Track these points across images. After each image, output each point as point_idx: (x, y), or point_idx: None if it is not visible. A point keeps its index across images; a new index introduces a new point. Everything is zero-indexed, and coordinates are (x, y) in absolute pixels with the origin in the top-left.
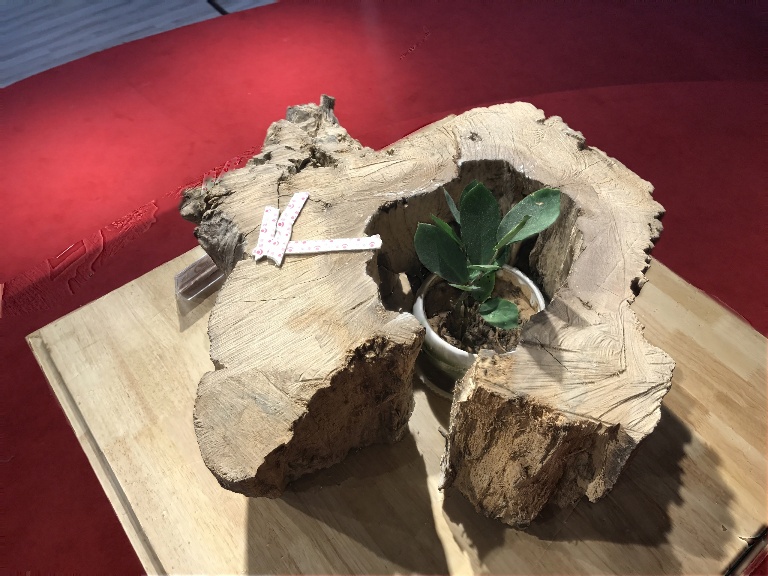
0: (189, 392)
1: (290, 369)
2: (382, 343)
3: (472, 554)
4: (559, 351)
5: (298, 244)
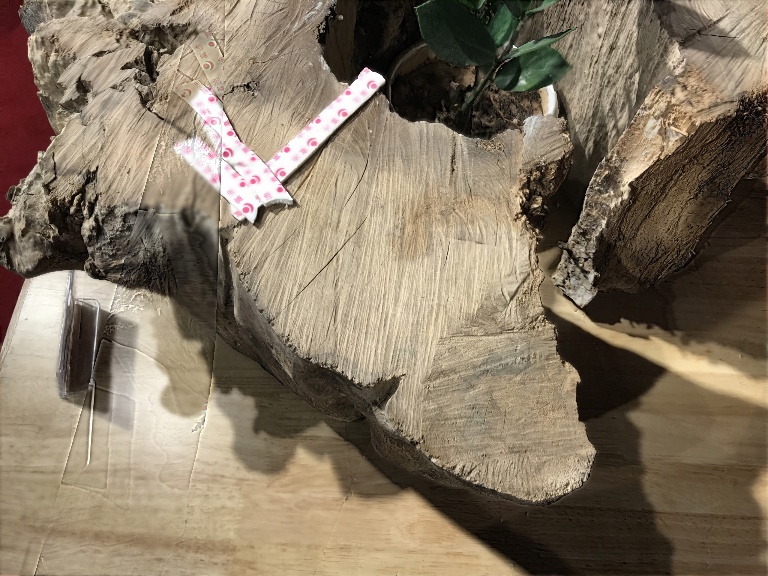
0: (228, 478)
1: (483, 299)
2: (541, 175)
3: (657, 333)
4: (715, 26)
5: (282, 158)
